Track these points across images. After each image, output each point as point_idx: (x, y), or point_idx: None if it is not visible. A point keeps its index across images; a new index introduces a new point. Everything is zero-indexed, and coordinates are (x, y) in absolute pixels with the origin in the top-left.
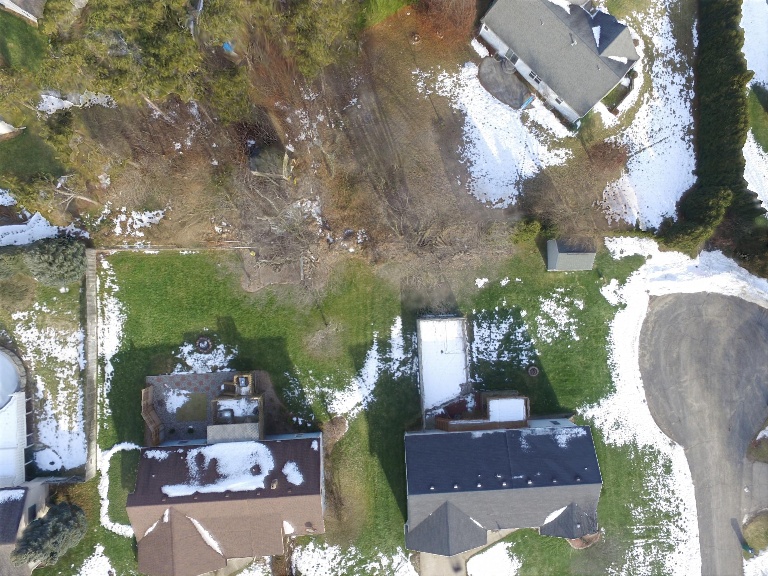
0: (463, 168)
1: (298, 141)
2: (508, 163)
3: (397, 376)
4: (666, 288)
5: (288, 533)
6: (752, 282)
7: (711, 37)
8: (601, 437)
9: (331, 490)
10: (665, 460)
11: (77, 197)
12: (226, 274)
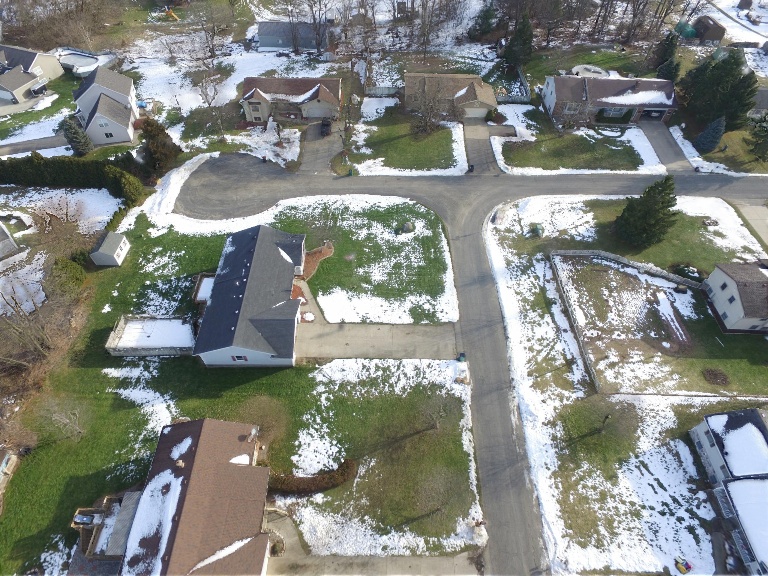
0: (4, 320)
1: None
2: (22, 289)
3: (156, 373)
4: (168, 204)
5: (248, 461)
6: None
7: (8, 175)
8: None
9: None
10: (287, 209)
11: None
12: None
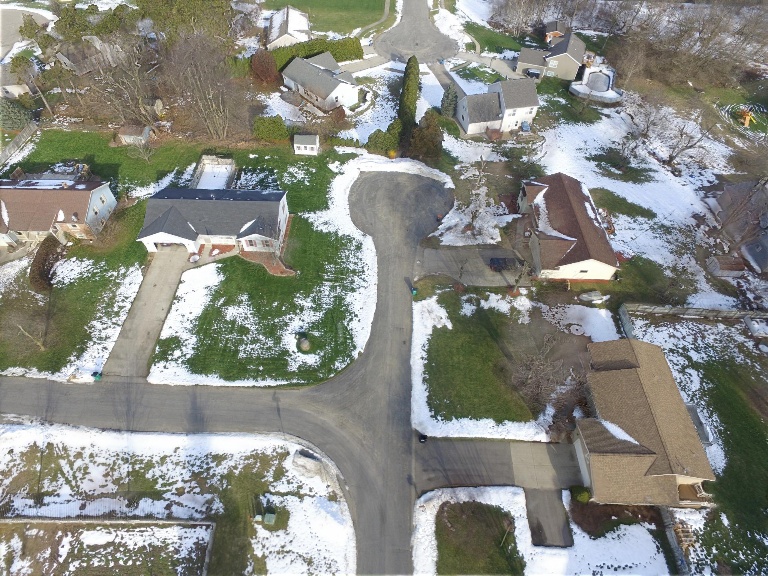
0: None
1: (173, 106)
2: None
3: (181, 185)
4: (370, 166)
5: (59, 221)
6: (427, 168)
7: None
8: (311, 226)
9: (107, 230)
10: (358, 243)
11: (42, 98)
12: (103, 140)
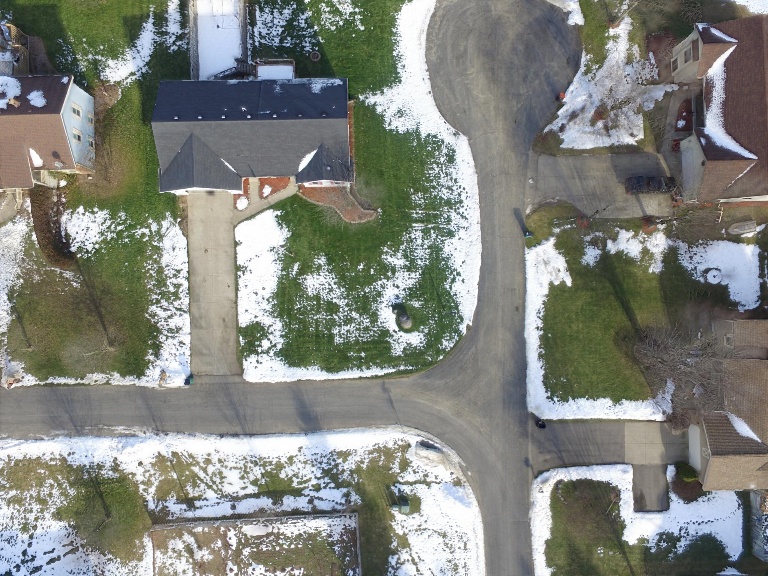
0: None
1: None
2: None
3: (173, 50)
4: None
5: (38, 166)
6: None
7: None
8: (382, 122)
9: (102, 155)
10: (449, 150)
11: None
12: None
